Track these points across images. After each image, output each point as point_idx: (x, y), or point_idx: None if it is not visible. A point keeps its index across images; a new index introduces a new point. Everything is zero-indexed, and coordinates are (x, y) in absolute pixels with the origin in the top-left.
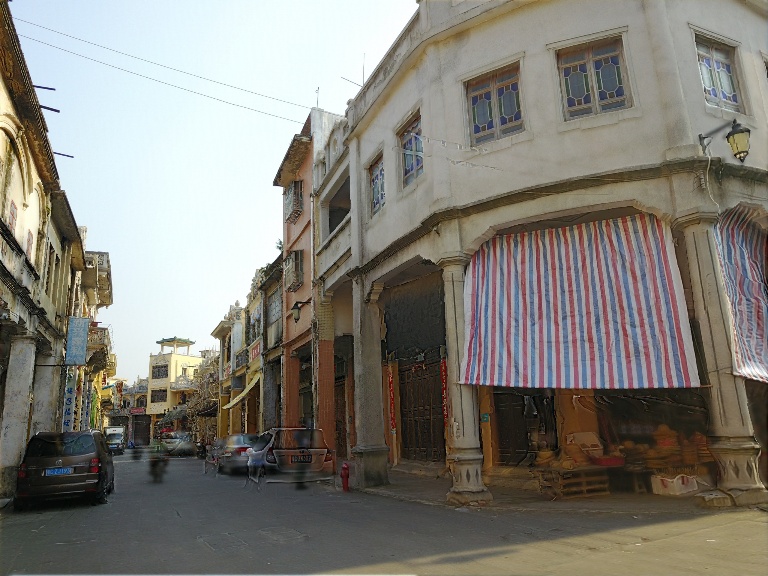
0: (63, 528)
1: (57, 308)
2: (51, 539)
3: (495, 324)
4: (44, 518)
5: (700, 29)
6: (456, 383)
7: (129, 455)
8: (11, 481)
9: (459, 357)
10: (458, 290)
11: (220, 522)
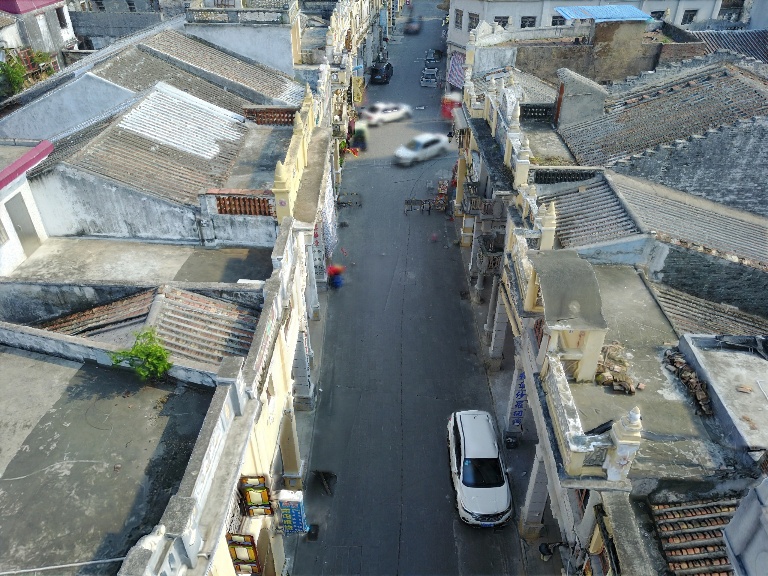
0: (379, 95)
1: (376, 6)
2: (376, 99)
3: (454, 70)
4: (376, 89)
5: (497, 15)
6: (446, 81)
7: (423, 0)
8: (370, 70)
9: (447, 76)
10: (449, 61)
11: (402, 100)
